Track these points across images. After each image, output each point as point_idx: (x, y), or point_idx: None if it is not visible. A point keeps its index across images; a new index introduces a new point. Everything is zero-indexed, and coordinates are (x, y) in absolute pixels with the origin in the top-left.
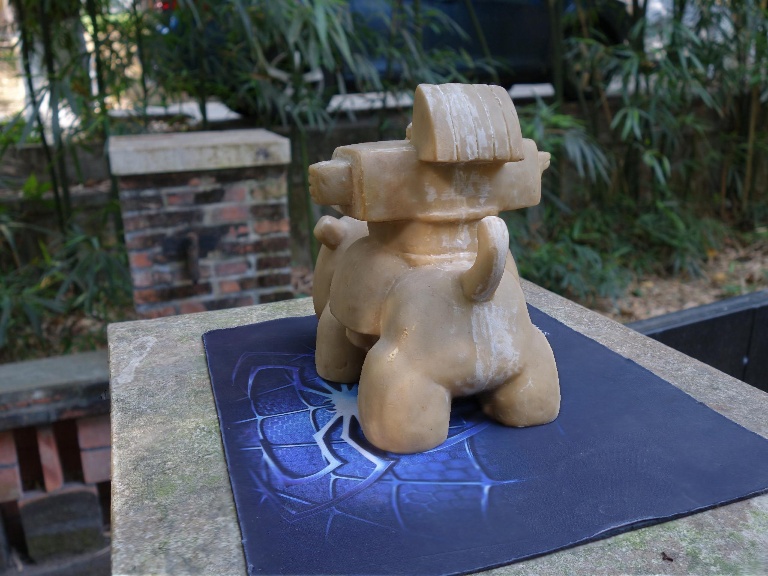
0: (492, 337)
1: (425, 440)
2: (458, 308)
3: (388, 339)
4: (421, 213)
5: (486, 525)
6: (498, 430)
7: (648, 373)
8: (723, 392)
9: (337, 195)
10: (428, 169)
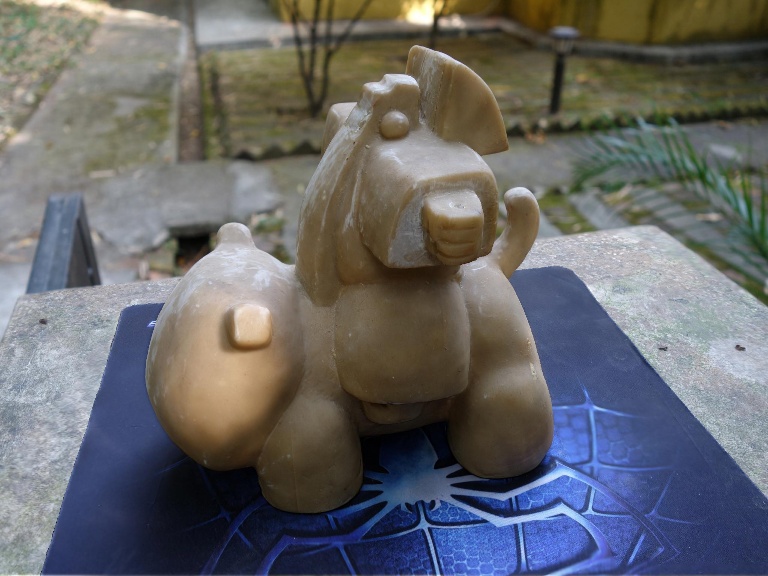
0: None
1: None
2: None
3: (514, 364)
4: None
5: (653, 418)
6: None
7: None
8: None
9: None
10: None
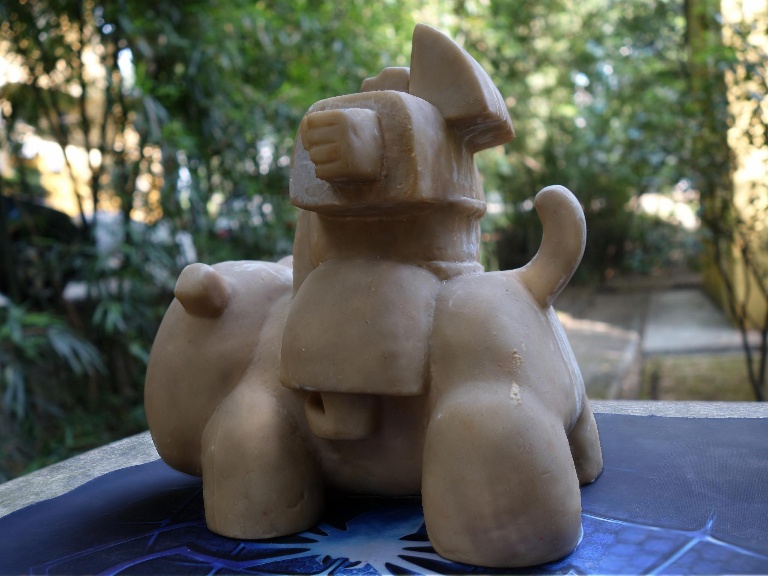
0: (569, 354)
1: None
2: (542, 316)
3: (486, 378)
4: (451, 196)
5: None
6: (582, 493)
7: None
8: (634, 409)
9: (370, 157)
10: (451, 135)
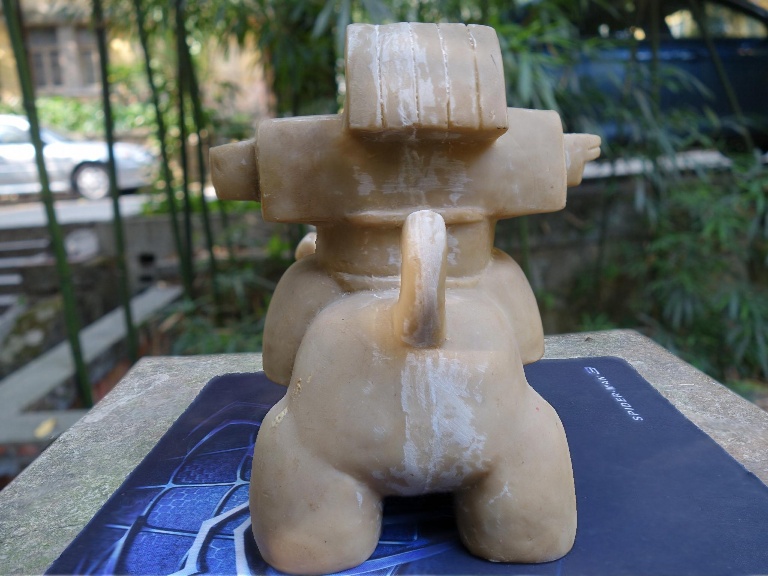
0: (435, 406)
1: (315, 557)
2: (380, 355)
3: None
4: (350, 212)
5: None
6: (455, 560)
7: None
8: None
9: (236, 185)
10: (358, 146)
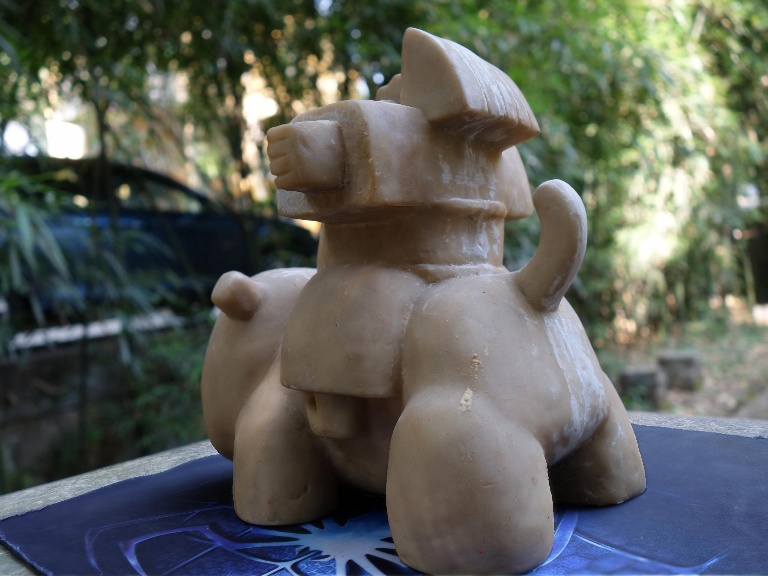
0: (575, 361)
1: (544, 539)
2: (530, 319)
3: (443, 383)
4: (438, 198)
5: None
6: (597, 514)
7: (664, 429)
8: (751, 430)
9: (325, 166)
10: (439, 136)
